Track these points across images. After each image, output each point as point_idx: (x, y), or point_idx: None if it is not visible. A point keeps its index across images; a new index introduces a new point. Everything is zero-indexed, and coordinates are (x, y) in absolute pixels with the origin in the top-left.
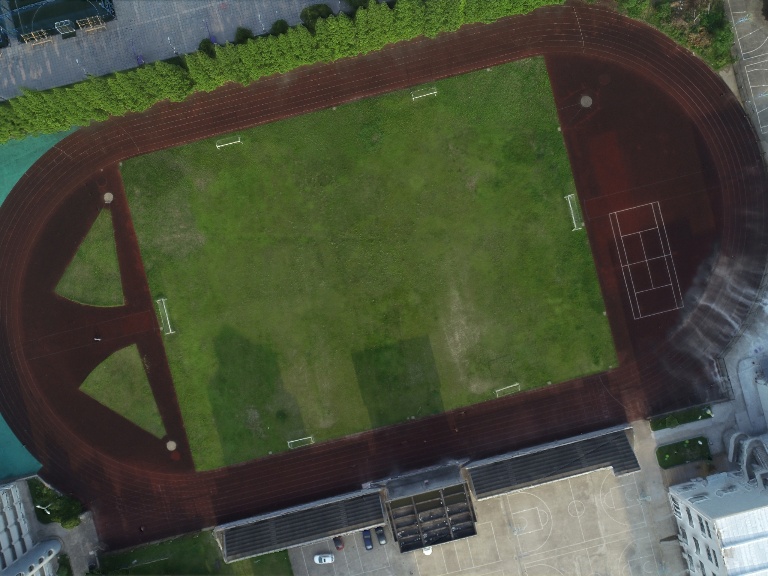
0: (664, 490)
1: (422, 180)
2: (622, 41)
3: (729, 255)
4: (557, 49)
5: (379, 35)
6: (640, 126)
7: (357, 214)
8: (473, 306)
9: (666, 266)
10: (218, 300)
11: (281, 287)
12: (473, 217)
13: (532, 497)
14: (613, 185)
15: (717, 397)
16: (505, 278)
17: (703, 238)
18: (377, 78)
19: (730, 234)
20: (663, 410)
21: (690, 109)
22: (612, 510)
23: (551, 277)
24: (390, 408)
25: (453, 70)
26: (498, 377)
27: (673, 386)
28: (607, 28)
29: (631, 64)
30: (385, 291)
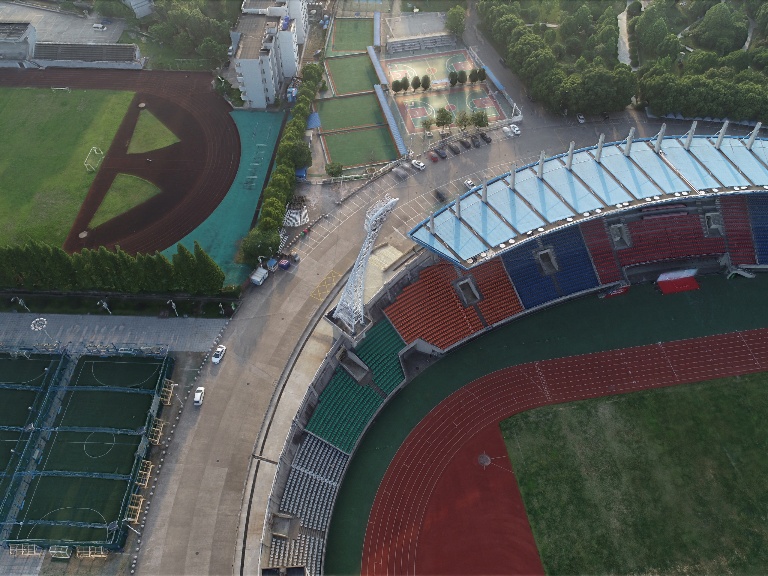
0: None
1: None
2: None
3: None
4: None
5: None
6: None
7: None
8: None
9: None
10: (54, 163)
11: (7, 160)
12: None
13: None
14: None
15: None
16: None
17: None
18: None
19: None
20: None
21: None
22: None
23: None
24: None
25: None
26: None
27: None
28: None
29: None
30: None
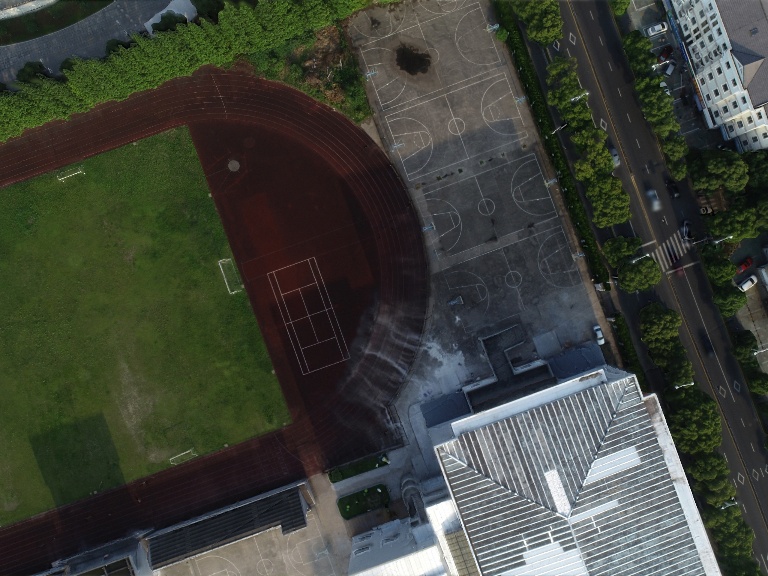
0: (349, 540)
1: (80, 258)
2: (263, 103)
3: (389, 303)
4: (200, 117)
5: (1, 125)
6: (289, 185)
7: (20, 297)
8: (143, 377)
9: (329, 320)
10: None
11: None
12: (134, 290)
13: (220, 560)
14: (268, 245)
15: (392, 444)
16: (172, 346)
17: (362, 289)
18: (26, 162)
19: (388, 282)
20: (341, 461)
21: (336, 164)
22: (300, 565)
23: (216, 341)
24: (72, 485)
25: (100, 147)
26: (175, 444)
27: (348, 437)
28: (246, 92)
29: (274, 125)
30: (55, 370)
